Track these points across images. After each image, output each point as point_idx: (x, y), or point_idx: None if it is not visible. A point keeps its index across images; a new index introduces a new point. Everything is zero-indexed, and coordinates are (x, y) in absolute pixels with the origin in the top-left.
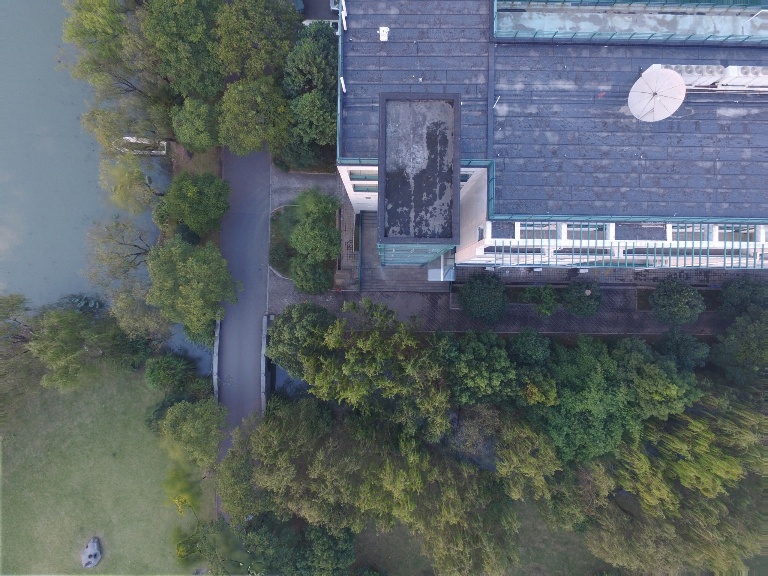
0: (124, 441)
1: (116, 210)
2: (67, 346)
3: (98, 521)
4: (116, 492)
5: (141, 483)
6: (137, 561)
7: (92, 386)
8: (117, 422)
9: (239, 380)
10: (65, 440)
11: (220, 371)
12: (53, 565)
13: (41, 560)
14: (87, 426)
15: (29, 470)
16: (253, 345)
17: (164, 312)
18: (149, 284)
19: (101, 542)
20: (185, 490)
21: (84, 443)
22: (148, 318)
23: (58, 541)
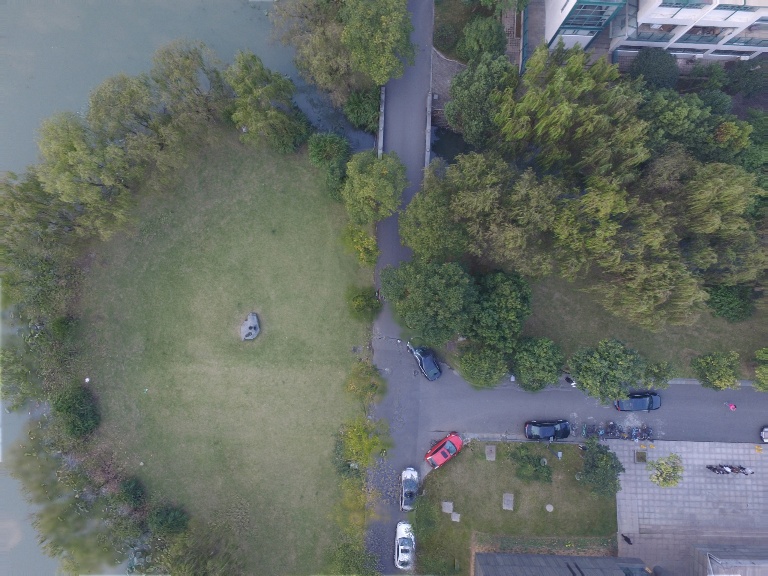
0: (284, 218)
1: None
2: (256, 88)
3: (256, 297)
4: (275, 268)
5: (300, 260)
6: (294, 337)
7: (251, 165)
8: (276, 200)
9: (403, 156)
10: (224, 217)
11: (384, 146)
12: (210, 340)
13: (198, 335)
14: (246, 203)
15: (187, 246)
16: (417, 123)
17: (356, 54)
18: (345, 21)
19: (259, 317)
20: (344, 268)
21: (243, 220)
22: (341, 58)
23: (215, 316)
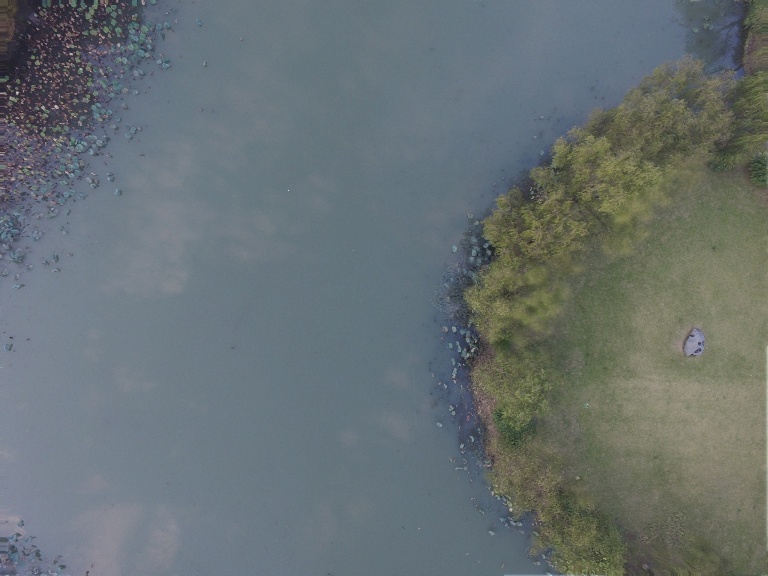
0: (723, 235)
1: (708, 12)
2: (767, 109)
3: (697, 313)
4: (715, 285)
5: (740, 276)
6: (735, 353)
7: (686, 182)
8: (714, 217)
9: None
10: (664, 233)
11: None
12: (651, 355)
13: (639, 350)
14: (686, 220)
15: (628, 262)
16: None
17: None
18: None
19: None
20: None
21: (684, 236)
22: None
23: (657, 332)
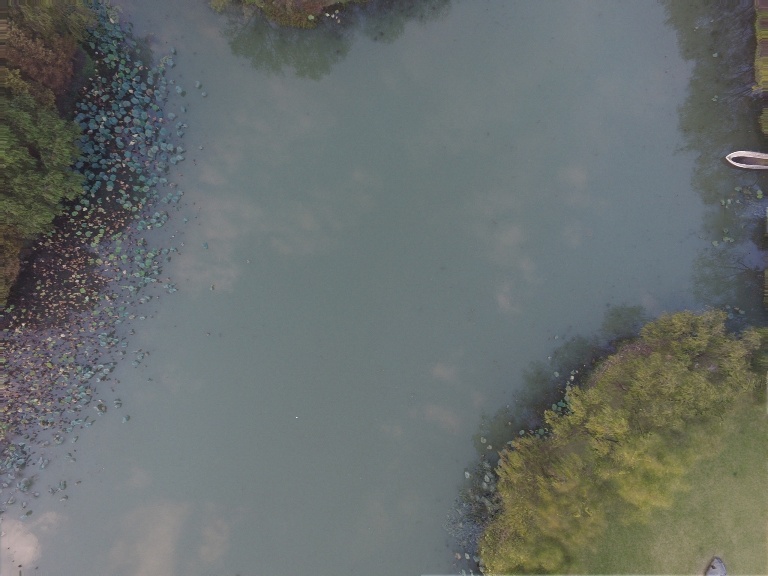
0: (745, 460)
1: (727, 225)
2: None
3: (718, 541)
4: (737, 512)
5: (763, 503)
6: None
7: None
8: (735, 441)
9: None
10: (683, 458)
11: None
12: None
13: None
14: (705, 445)
15: (646, 489)
16: None
17: None
18: None
19: None
20: None
21: (704, 462)
22: None
23: (677, 561)
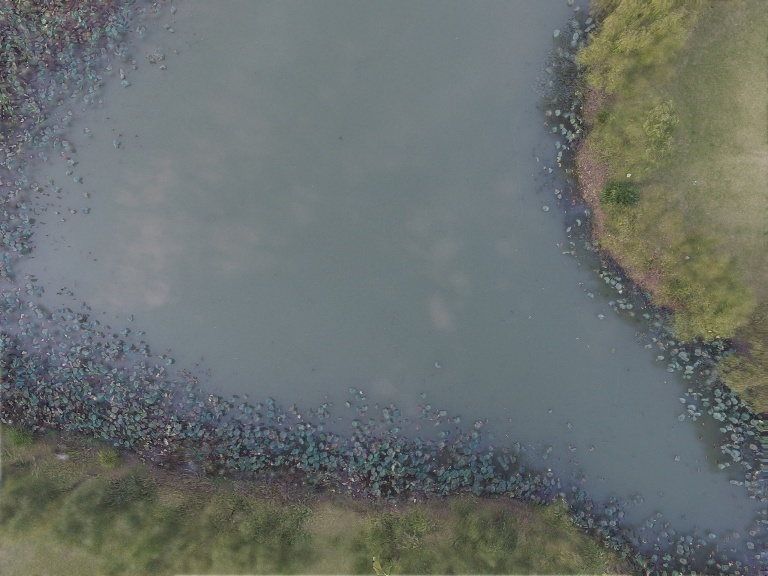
0: None
1: None
2: None
3: None
4: None
5: None
6: None
7: None
8: None
9: None
10: (766, 10)
11: None
12: (758, 131)
13: (746, 126)
14: None
15: (731, 39)
16: None
17: None
18: None
19: None
20: None
21: None
22: None
23: (763, 107)
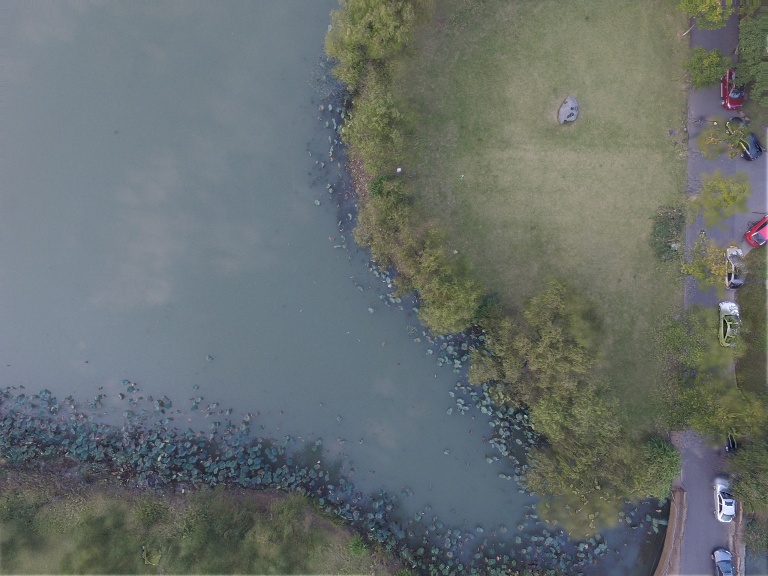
0: (596, 5)
1: None
2: None
3: (571, 82)
4: (589, 54)
5: (614, 45)
6: (611, 121)
7: None
8: None
9: None
10: (537, 5)
11: None
12: (526, 125)
13: (514, 120)
14: None
15: (501, 34)
16: None
17: None
18: None
19: None
20: (658, 53)
21: (556, 7)
22: None
23: (531, 102)
